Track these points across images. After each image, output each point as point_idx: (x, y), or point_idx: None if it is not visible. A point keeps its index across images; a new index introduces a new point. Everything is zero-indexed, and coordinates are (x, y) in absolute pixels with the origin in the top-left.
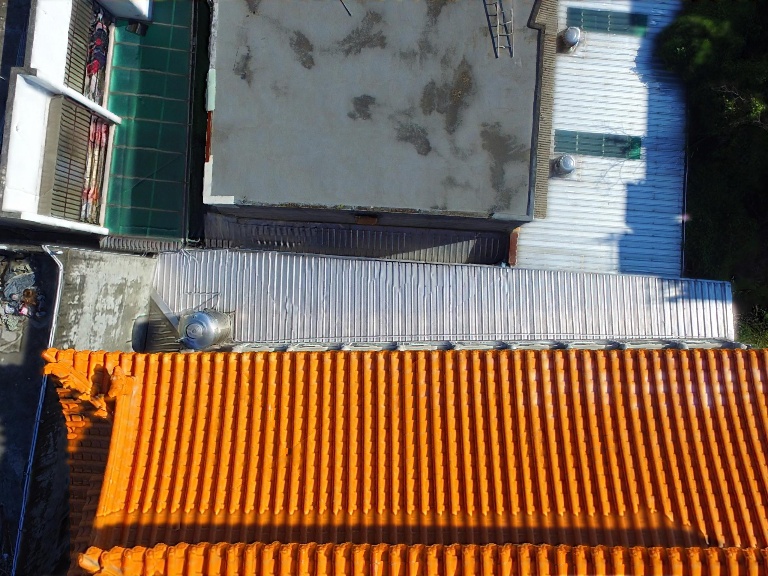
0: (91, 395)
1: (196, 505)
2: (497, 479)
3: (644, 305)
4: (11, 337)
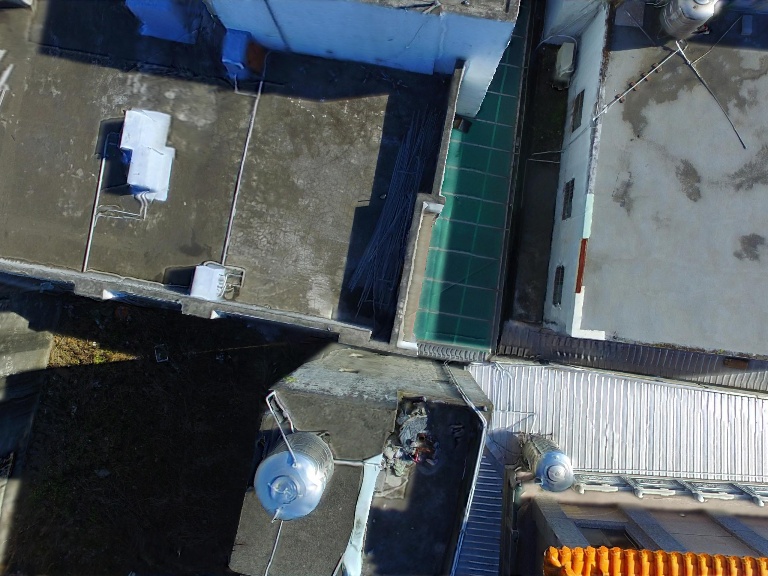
0: None
1: None
2: None
3: None
4: (396, 482)
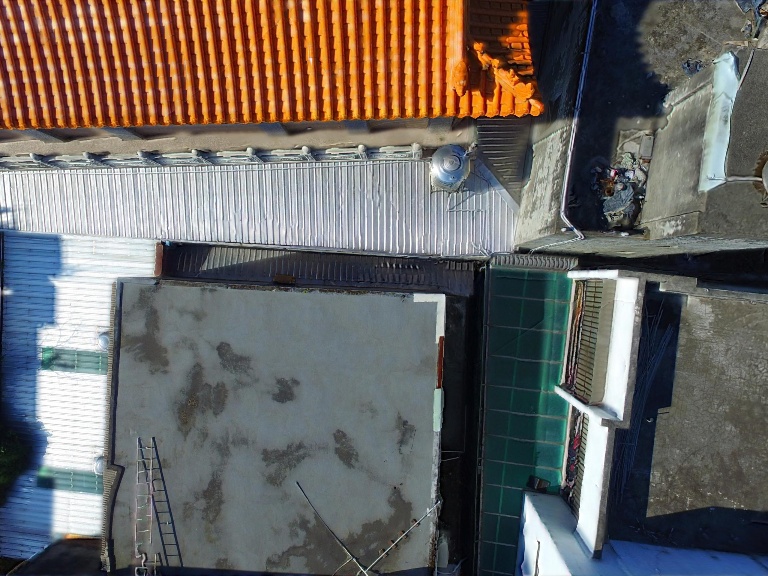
0: (493, 67)
1: None
2: None
3: (31, 204)
4: (630, 146)
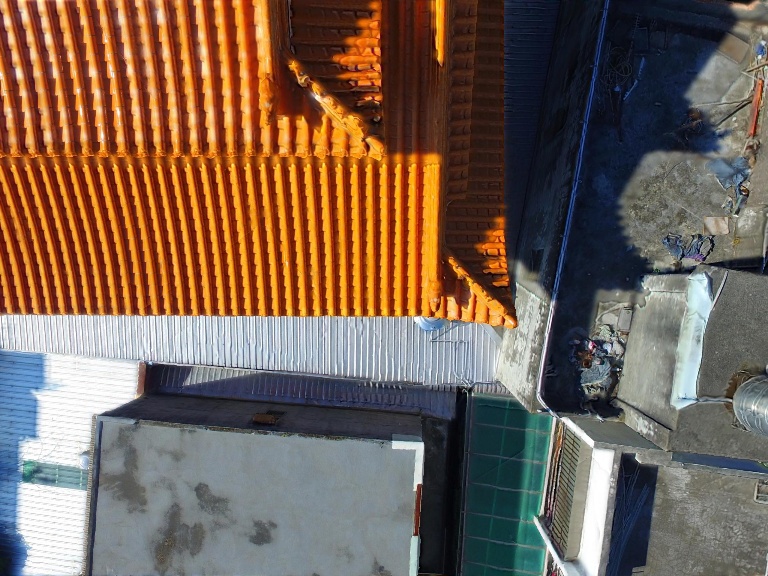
0: (467, 280)
1: (348, 171)
2: (52, 197)
3: (14, 323)
4: (609, 318)
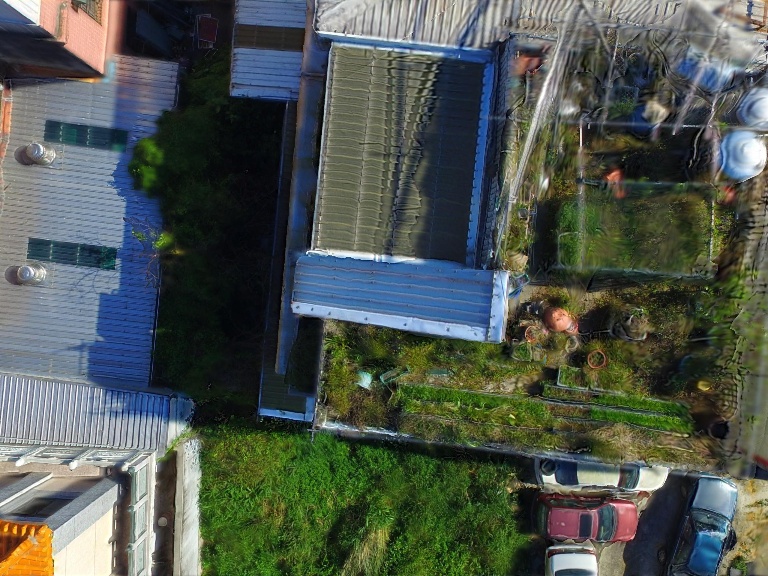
0: None
1: None
2: None
3: (86, 414)
4: None
